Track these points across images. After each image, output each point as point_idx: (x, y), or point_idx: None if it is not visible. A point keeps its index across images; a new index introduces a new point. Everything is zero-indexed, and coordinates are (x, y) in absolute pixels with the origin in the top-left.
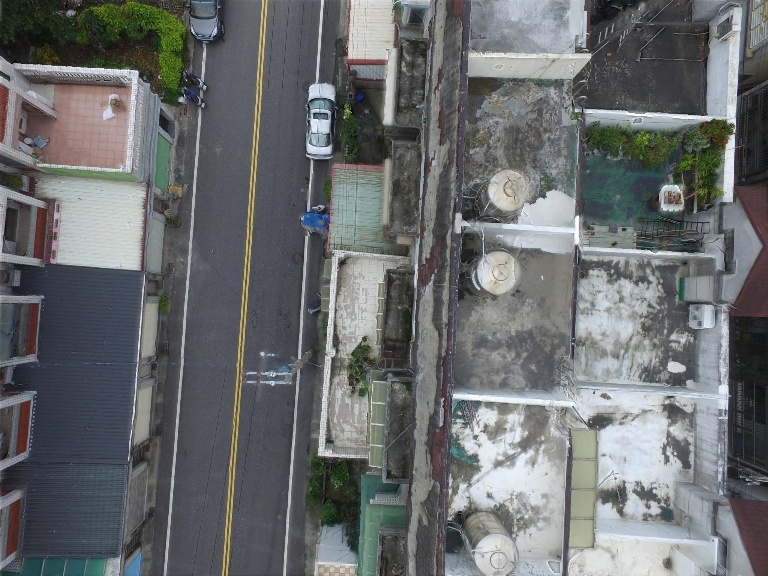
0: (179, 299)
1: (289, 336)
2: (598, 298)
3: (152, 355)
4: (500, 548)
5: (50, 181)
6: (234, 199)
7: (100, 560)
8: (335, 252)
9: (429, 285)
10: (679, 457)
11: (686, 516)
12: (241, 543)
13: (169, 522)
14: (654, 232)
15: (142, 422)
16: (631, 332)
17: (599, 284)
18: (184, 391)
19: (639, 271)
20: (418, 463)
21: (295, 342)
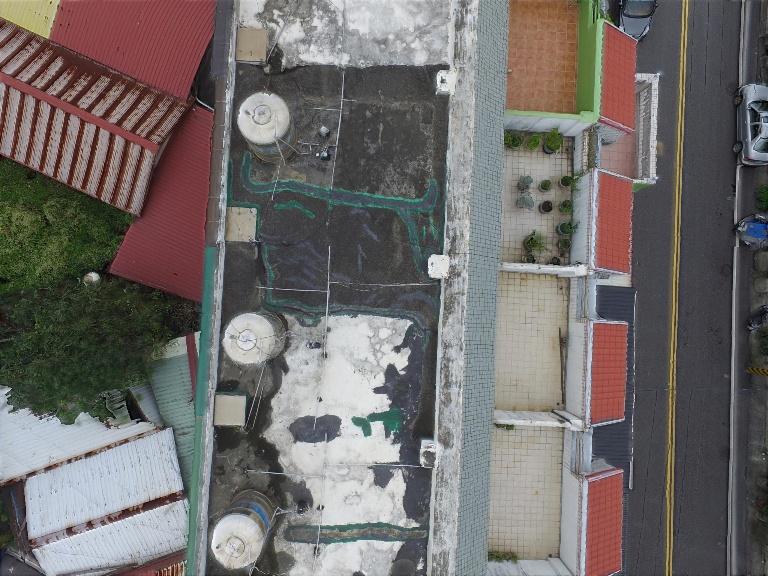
0: None
1: (721, 353)
2: None
3: None
4: None
5: None
6: (659, 208)
7: None
8: None
9: None
10: None
11: None
12: (682, 571)
13: None
14: None
15: None
16: None
17: None
18: None
19: None
20: None
21: (728, 359)
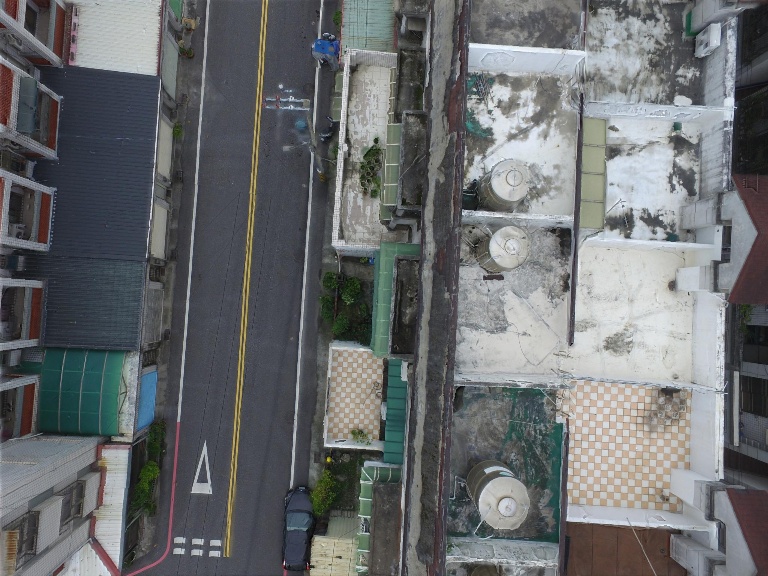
0: (193, 128)
1: (301, 165)
2: (606, 35)
3: (167, 178)
4: (515, 167)
5: None
6: (246, 31)
7: (119, 354)
8: (347, 50)
9: None
10: (685, 185)
11: (692, 230)
12: (255, 363)
13: (184, 342)
14: None
15: (158, 238)
16: (639, 68)
17: (607, 22)
18: (198, 217)
19: (646, 9)
20: (435, 136)
21: (306, 170)
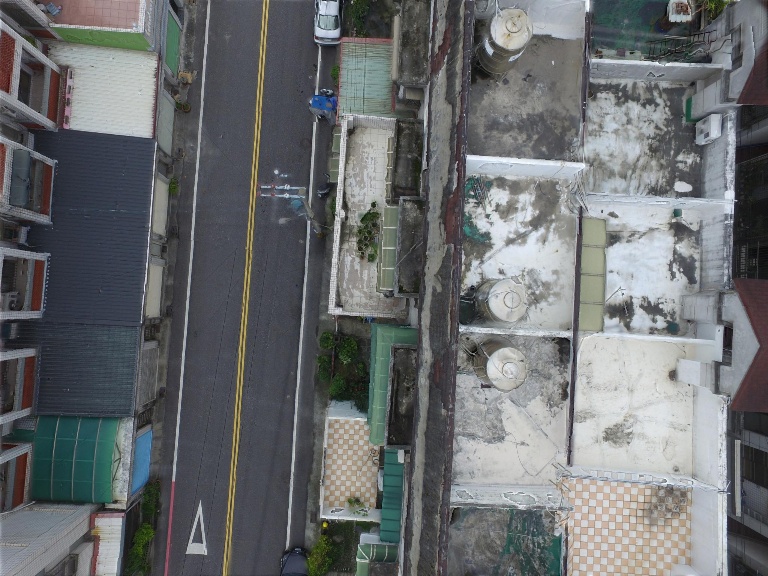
0: (189, 183)
1: (298, 220)
2: (606, 120)
3: (163, 235)
4: (513, 289)
5: (63, 48)
6: (243, 85)
7: (113, 420)
8: (345, 115)
9: (442, 69)
10: (685, 273)
11: (692, 322)
12: (251, 421)
13: (180, 401)
14: (661, 52)
15: (153, 297)
16: (638, 153)
17: (607, 106)
18: (194, 273)
19: (646, 94)
20: (431, 241)
21: (304, 226)
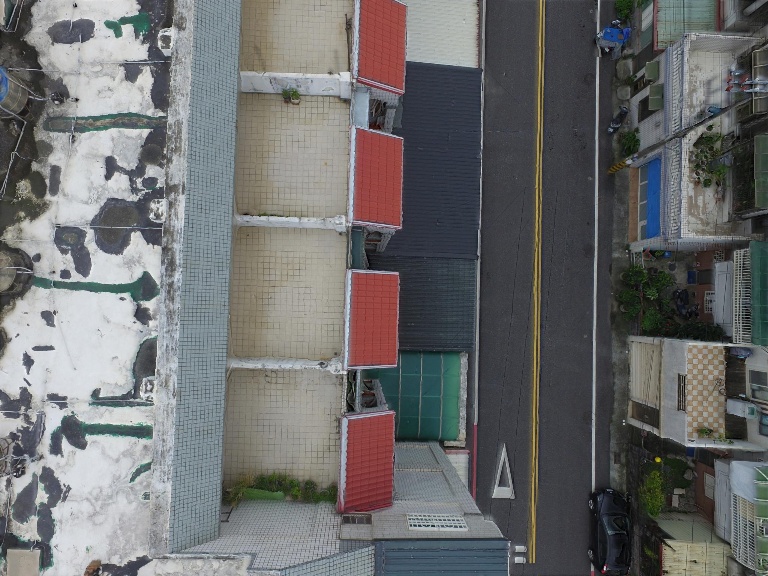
0: None
1: (585, 157)
2: None
3: None
4: None
5: None
6: (524, 21)
7: (453, 356)
8: (687, 35)
9: None
10: None
11: None
12: (550, 362)
13: (477, 343)
14: None
15: None
16: None
17: None
18: (483, 214)
19: None
20: None
21: (592, 163)
